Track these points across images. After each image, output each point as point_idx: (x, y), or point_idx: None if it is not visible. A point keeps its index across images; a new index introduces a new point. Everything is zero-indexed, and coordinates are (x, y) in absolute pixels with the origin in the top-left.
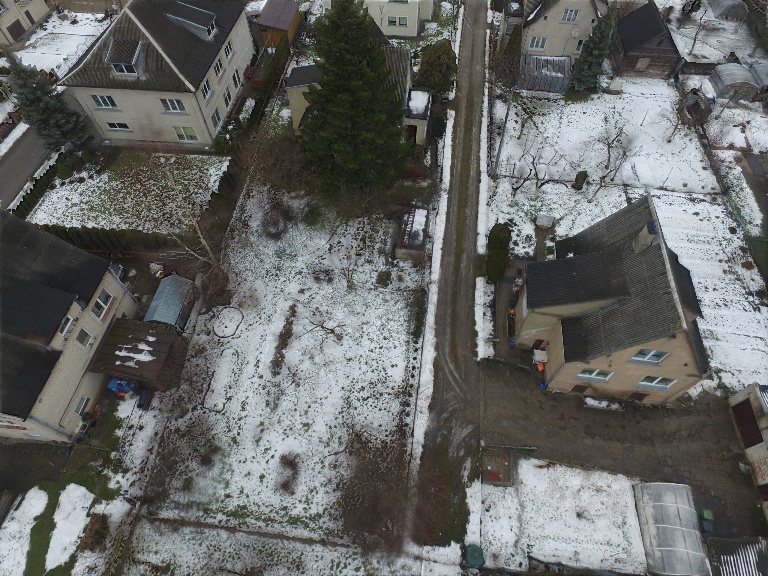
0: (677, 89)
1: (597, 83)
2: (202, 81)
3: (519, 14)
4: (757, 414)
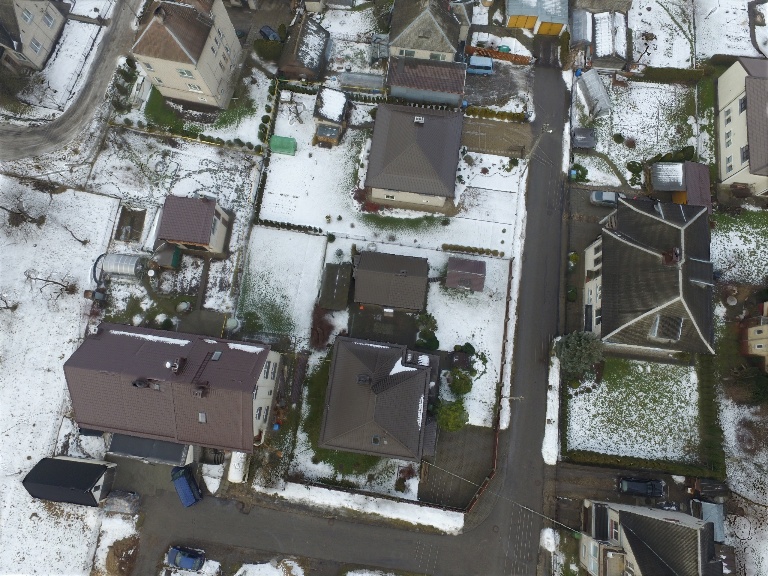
0: None
1: None
2: None
3: None
4: None
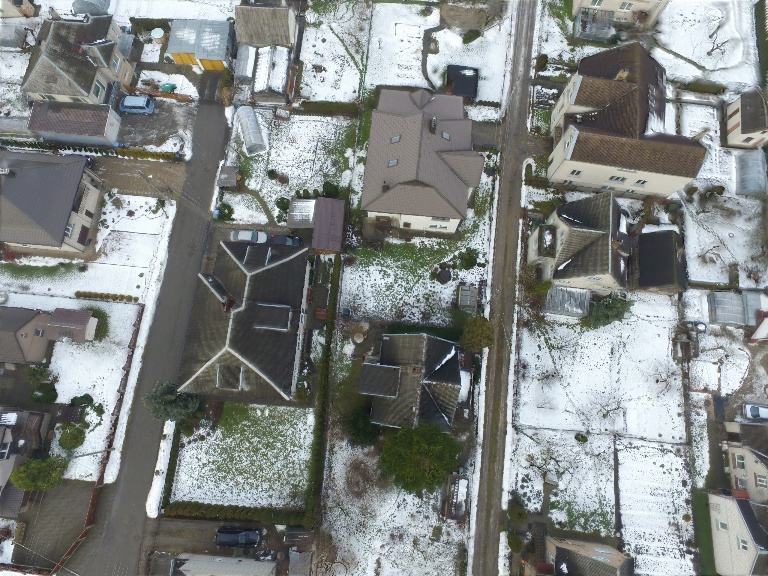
0: (678, 310)
1: None
2: None
3: (551, 254)
4: None
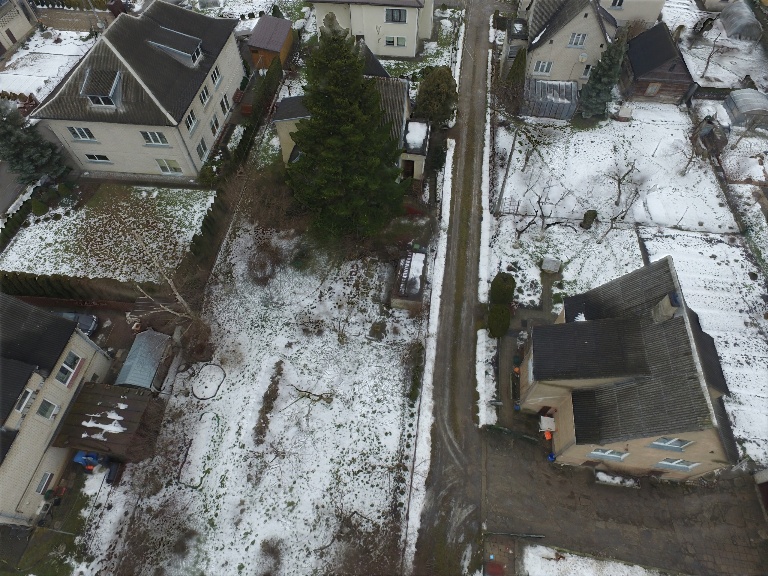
0: (690, 115)
1: (605, 109)
2: (185, 112)
3: (523, 36)
4: None
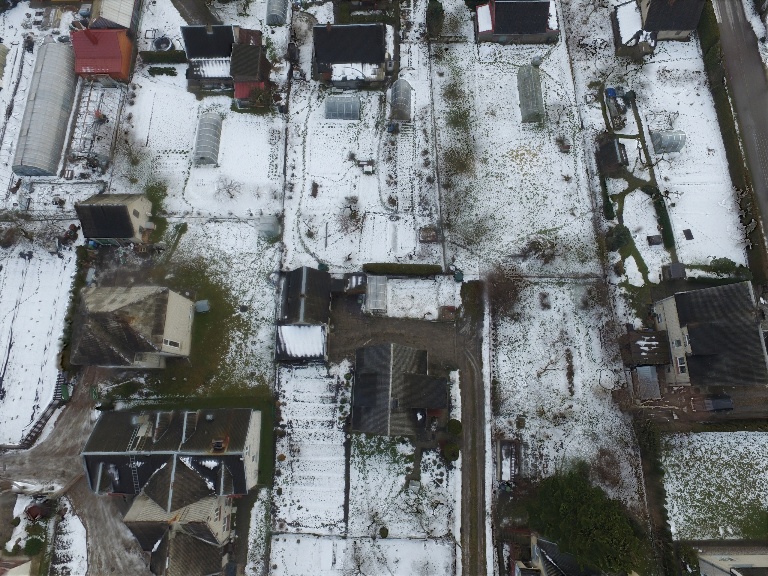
0: None
1: None
2: None
3: None
4: None
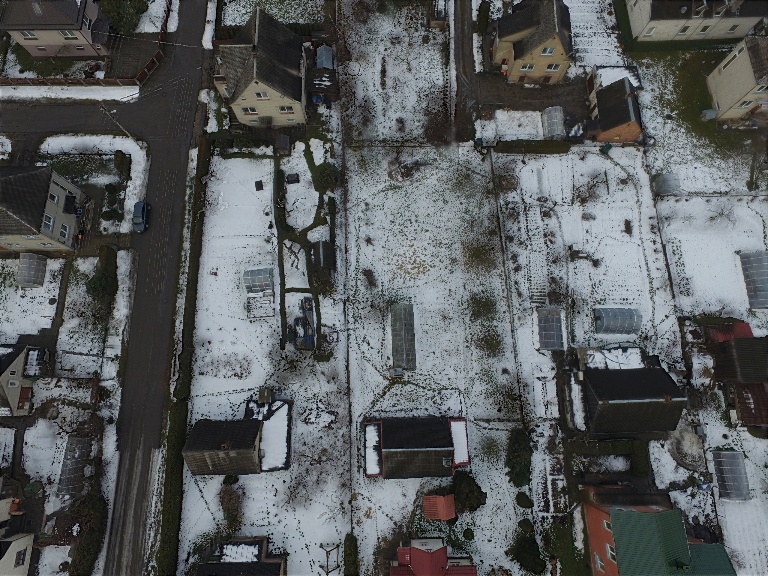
0: None
1: None
2: None
3: None
4: (594, 78)
